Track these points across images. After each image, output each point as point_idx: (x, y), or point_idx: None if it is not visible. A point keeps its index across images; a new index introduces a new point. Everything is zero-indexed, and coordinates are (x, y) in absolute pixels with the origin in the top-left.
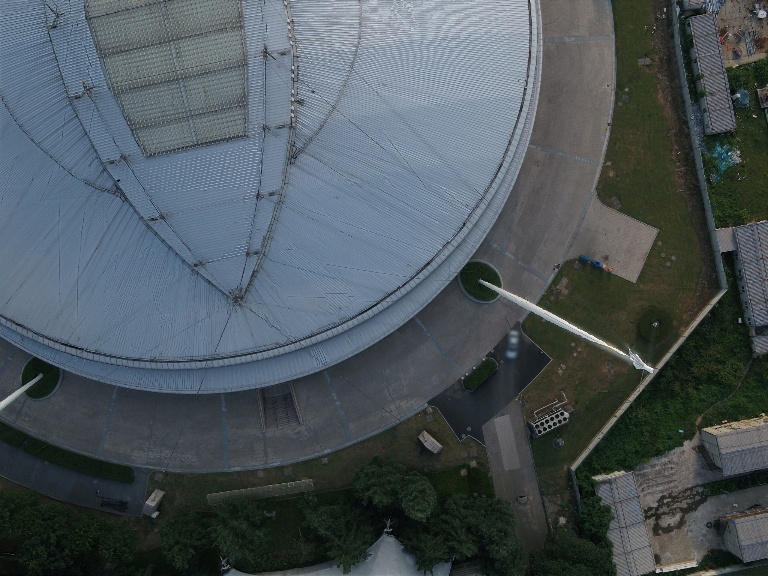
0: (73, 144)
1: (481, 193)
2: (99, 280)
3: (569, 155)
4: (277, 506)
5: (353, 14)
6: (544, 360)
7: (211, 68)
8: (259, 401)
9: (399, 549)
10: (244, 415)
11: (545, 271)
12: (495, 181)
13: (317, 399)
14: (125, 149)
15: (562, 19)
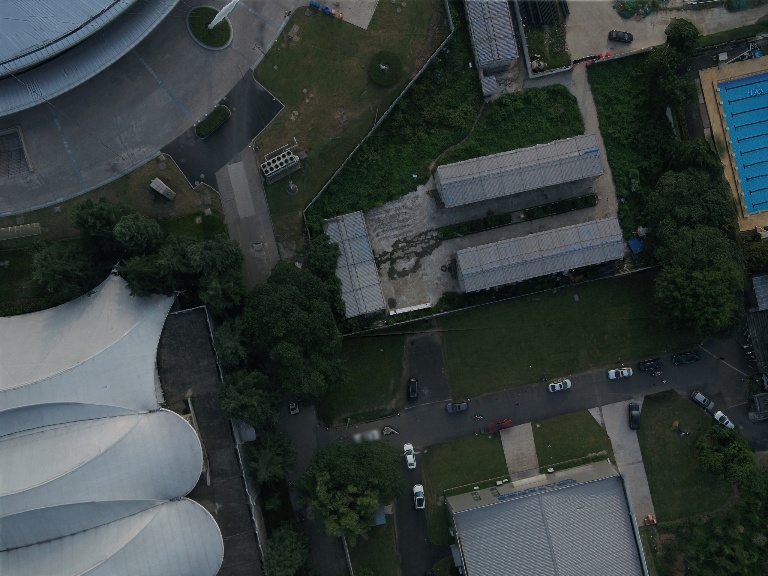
0: None
1: None
2: None
3: None
4: (10, 256)
5: None
6: (277, 107)
7: None
8: None
9: (123, 286)
10: None
11: (276, 18)
12: None
13: (48, 147)
14: None
15: None
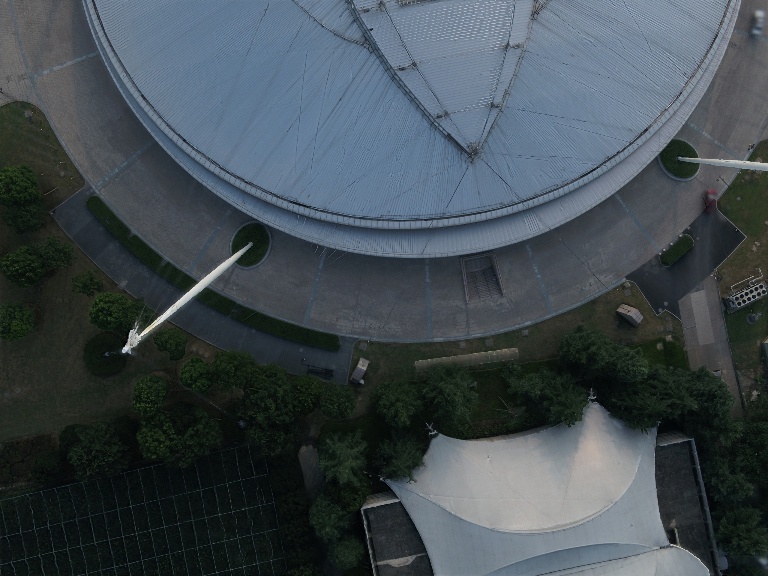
0: None
1: (697, 62)
2: (338, 134)
3: (764, 38)
4: (478, 377)
5: None
6: (739, 237)
7: None
8: (464, 272)
9: (605, 414)
10: (447, 287)
11: (740, 151)
12: (710, 51)
13: (519, 272)
14: None
15: None
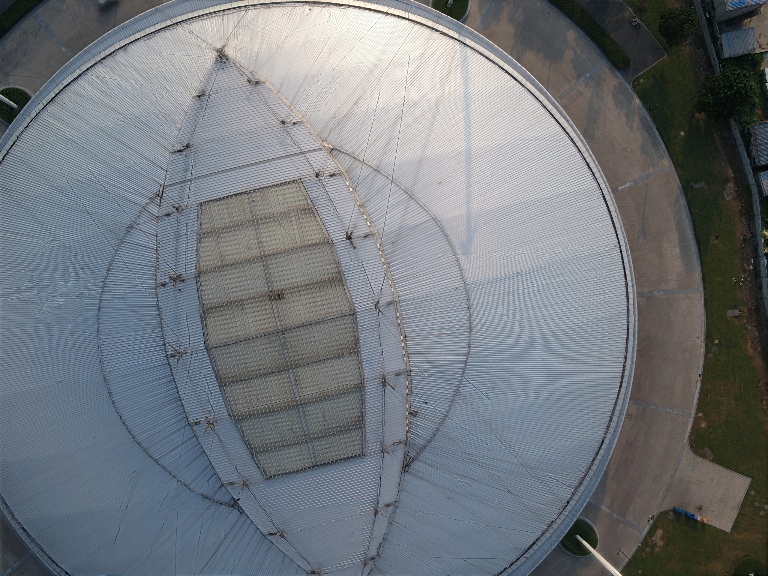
0: (191, 461)
1: (584, 471)
2: None
3: (661, 408)
4: None
5: (463, 324)
6: None
7: (329, 394)
8: None
9: None
10: None
11: (640, 523)
12: (597, 458)
13: None
14: (245, 471)
15: (651, 273)
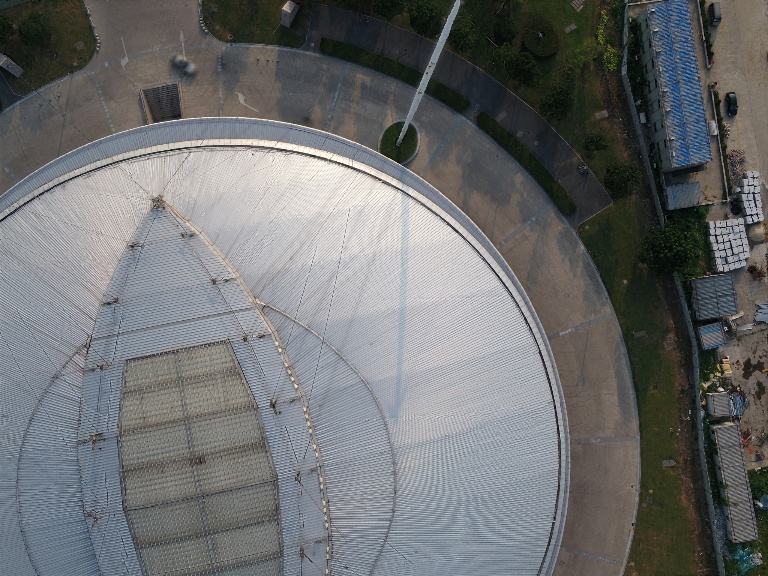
0: None
1: None
2: None
3: (593, 555)
4: None
5: (388, 488)
6: None
7: (247, 561)
8: None
9: None
10: None
11: None
12: None
13: None
14: None
15: (588, 420)
